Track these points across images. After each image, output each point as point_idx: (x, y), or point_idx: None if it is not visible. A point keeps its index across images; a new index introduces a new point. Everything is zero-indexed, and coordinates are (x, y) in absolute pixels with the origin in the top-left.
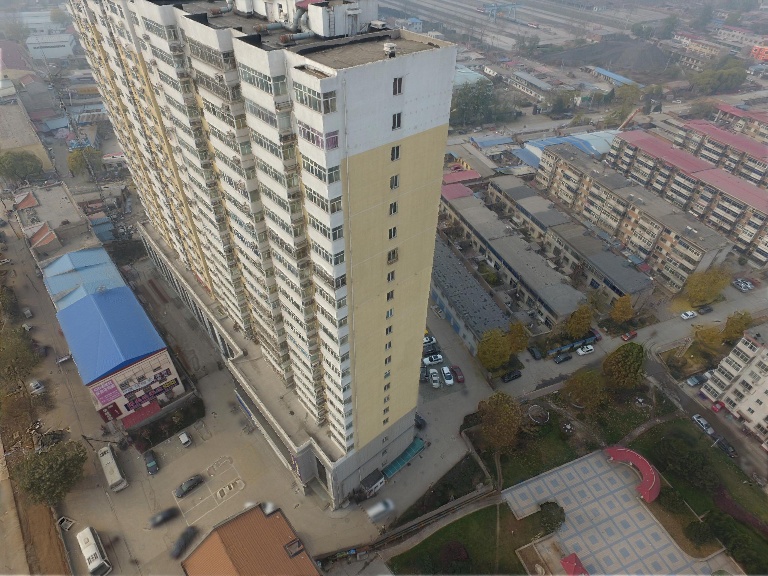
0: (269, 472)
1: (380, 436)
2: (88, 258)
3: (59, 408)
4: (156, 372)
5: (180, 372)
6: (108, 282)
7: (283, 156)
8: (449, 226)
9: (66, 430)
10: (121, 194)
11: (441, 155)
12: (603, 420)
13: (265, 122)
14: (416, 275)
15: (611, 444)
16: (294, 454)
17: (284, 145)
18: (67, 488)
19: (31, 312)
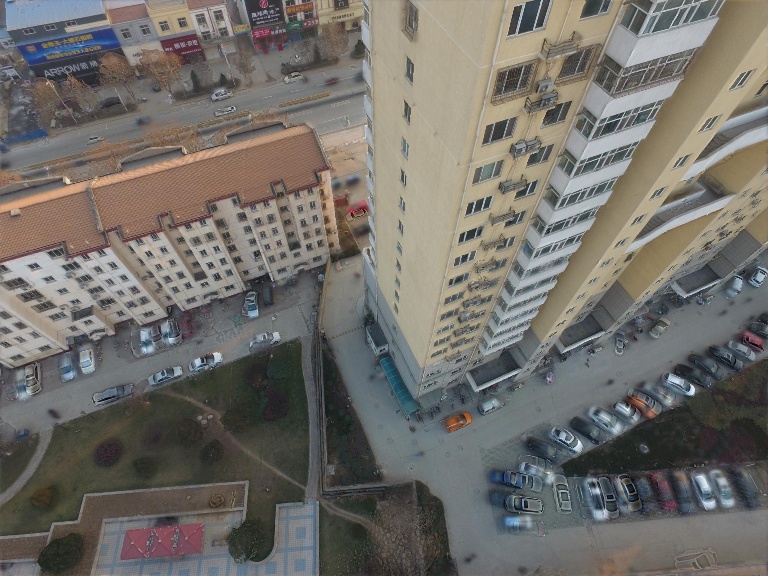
0: None
1: None
2: None
3: None
4: None
5: None
6: None
7: None
8: None
9: None
10: None
11: None
12: None
13: None
14: (437, 138)
15: None
16: None
17: None
18: None
19: None
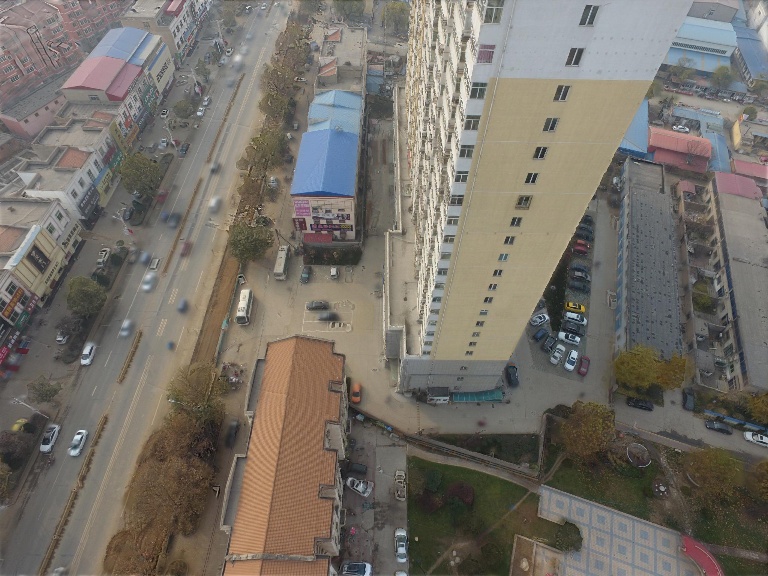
0: (372, 333)
1: (459, 362)
2: (347, 100)
3: (277, 204)
4: (340, 212)
5: (359, 222)
6: (348, 125)
7: (460, 57)
8: (697, 221)
9: (273, 221)
10: None
11: (627, 116)
12: (710, 512)
13: (460, 17)
14: (548, 235)
15: (699, 539)
16: (386, 329)
17: (463, 46)
18: (252, 258)
19: (298, 126)
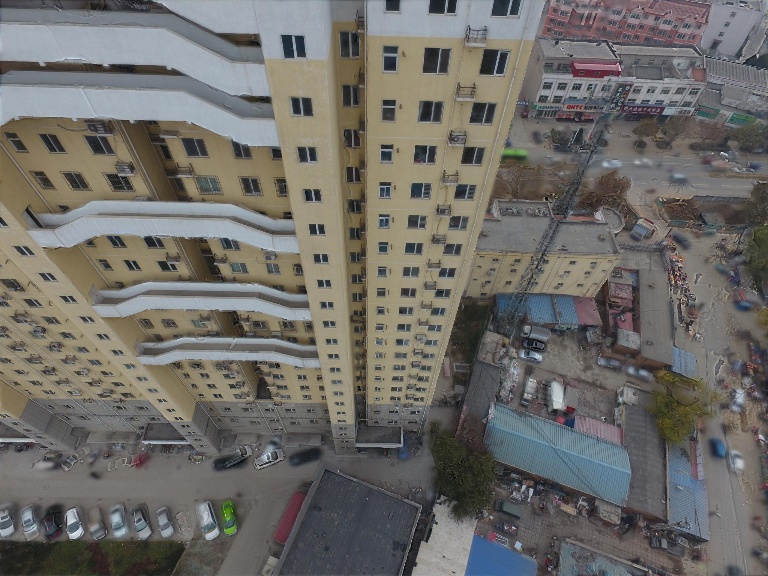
0: None
1: None
2: None
3: None
4: None
5: None
6: None
7: None
8: None
9: None
10: (652, 360)
11: None
12: None
13: None
14: None
15: None
16: None
17: None
18: None
19: None
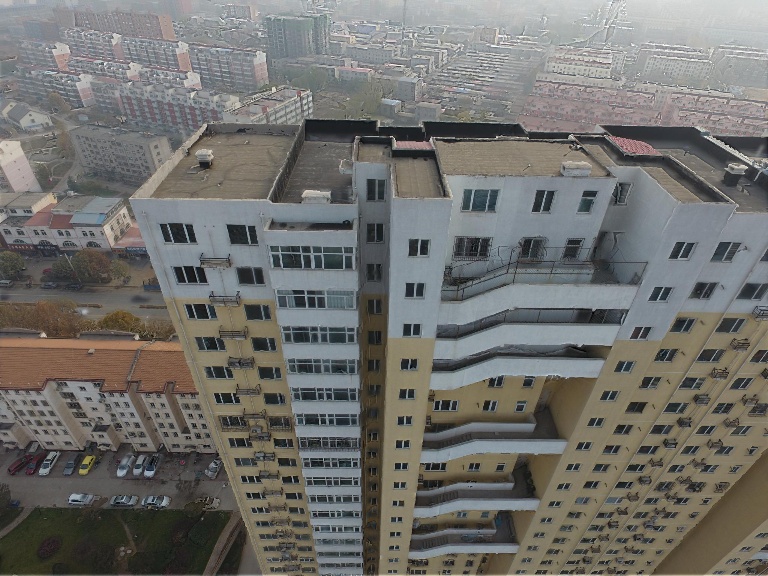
0: None
1: None
2: None
3: None
4: None
5: None
6: None
7: None
8: None
9: None
10: None
11: None
12: None
13: None
14: None
15: None
16: None
17: None
18: None
19: None
